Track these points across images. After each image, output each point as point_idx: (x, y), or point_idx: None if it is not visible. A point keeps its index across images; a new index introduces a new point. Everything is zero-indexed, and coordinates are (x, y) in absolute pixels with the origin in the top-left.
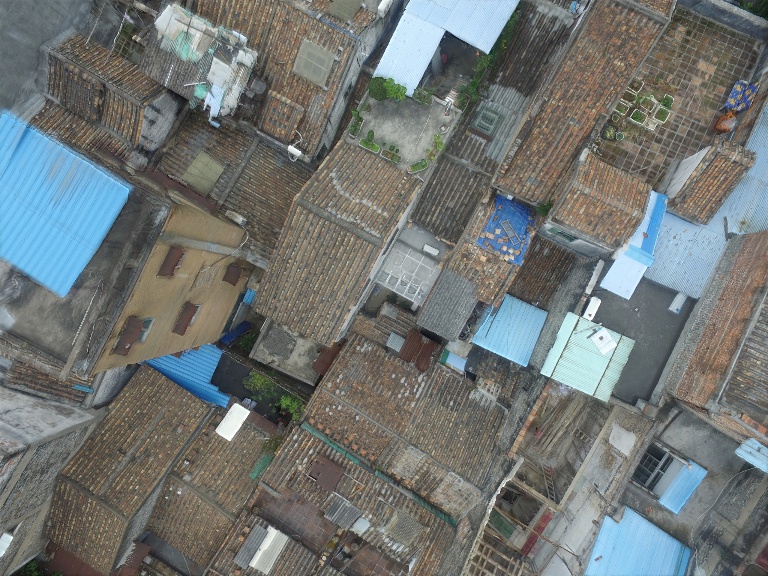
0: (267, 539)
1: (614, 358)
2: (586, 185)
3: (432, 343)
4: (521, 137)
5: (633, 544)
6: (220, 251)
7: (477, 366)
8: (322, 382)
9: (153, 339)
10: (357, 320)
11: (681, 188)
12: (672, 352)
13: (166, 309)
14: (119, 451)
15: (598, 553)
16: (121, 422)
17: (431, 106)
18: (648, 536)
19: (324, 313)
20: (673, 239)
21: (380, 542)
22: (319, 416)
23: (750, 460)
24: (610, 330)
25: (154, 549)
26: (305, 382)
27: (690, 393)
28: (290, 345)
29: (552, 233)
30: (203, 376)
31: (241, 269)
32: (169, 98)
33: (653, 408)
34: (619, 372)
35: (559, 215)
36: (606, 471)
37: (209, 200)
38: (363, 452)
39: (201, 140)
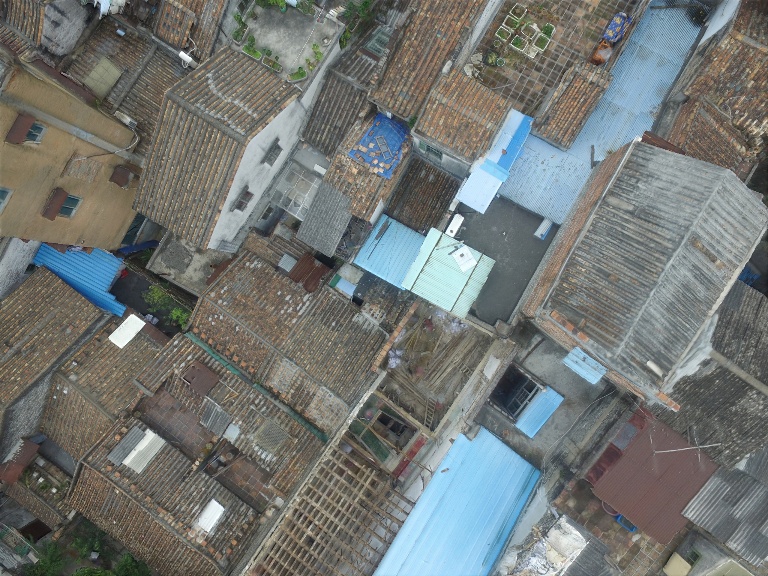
0: (144, 441)
1: (474, 276)
2: (445, 95)
3: (324, 267)
4: (389, 47)
5: (482, 461)
6: (98, 144)
7: (366, 292)
8: (205, 291)
9: (15, 215)
10: (250, 237)
11: (546, 110)
12: (533, 276)
13: (29, 187)
14: (5, 344)
15: (445, 466)
16: (12, 318)
17: (315, 18)
18: (499, 456)
19: (197, 213)
20: (541, 164)
21: (250, 450)
22: (203, 326)
23: (576, 370)
24: (472, 248)
25: (50, 454)
26: (198, 296)
27: (530, 305)
28: (186, 259)
29: (424, 151)
30: (101, 284)
31: (129, 171)
32: (75, 2)
33: (505, 325)
34: (478, 290)
35: (421, 126)
36: (472, 396)
37: (106, 104)
38: (243, 364)
39: (107, 48)
